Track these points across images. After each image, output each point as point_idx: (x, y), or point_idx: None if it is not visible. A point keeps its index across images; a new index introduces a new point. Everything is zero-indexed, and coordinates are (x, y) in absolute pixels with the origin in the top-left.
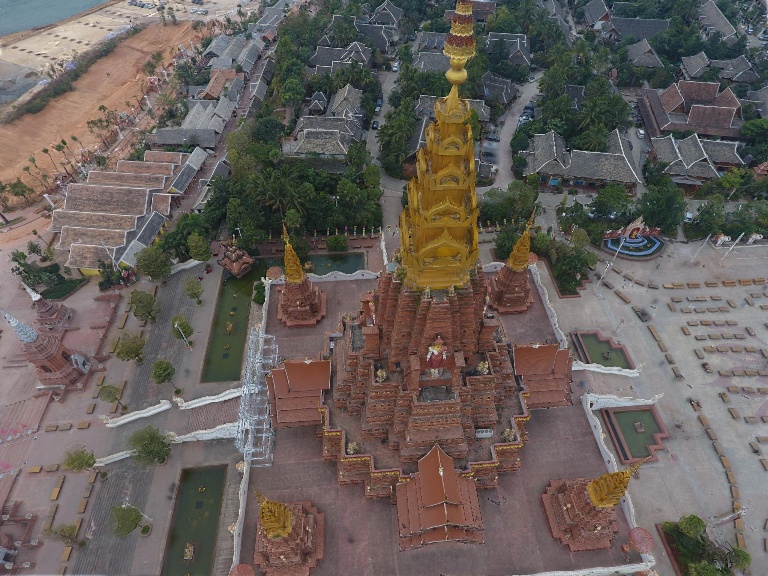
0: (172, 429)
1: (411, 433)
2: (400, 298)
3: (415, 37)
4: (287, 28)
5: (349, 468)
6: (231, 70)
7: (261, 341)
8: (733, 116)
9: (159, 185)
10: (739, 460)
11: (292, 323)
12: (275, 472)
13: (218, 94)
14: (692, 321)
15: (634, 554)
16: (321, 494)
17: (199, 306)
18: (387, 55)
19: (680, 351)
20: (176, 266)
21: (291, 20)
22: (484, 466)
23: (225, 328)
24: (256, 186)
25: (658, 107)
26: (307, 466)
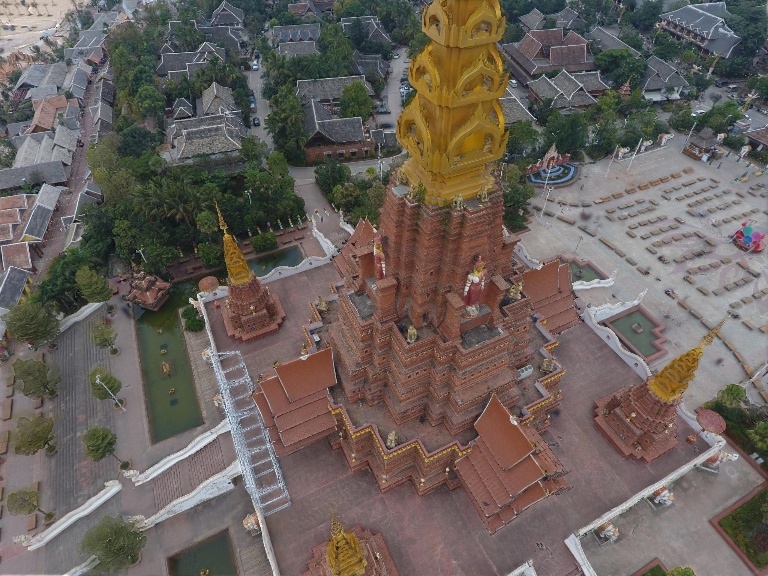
0: (133, 514)
1: (459, 394)
2: (422, 224)
3: (264, 36)
4: (118, 41)
5: (391, 467)
6: (59, 97)
7: (219, 366)
8: (585, 52)
9: (5, 236)
10: (727, 328)
11: (249, 336)
12: (298, 510)
13: (51, 125)
14: (632, 225)
15: (699, 442)
16: (365, 513)
17: (115, 356)
18: (241, 56)
19: (635, 252)
20: (64, 321)
21: (118, 35)
22: (539, 406)
23: (161, 371)
24: (146, 199)
25: (520, 57)
26: (335, 488)
